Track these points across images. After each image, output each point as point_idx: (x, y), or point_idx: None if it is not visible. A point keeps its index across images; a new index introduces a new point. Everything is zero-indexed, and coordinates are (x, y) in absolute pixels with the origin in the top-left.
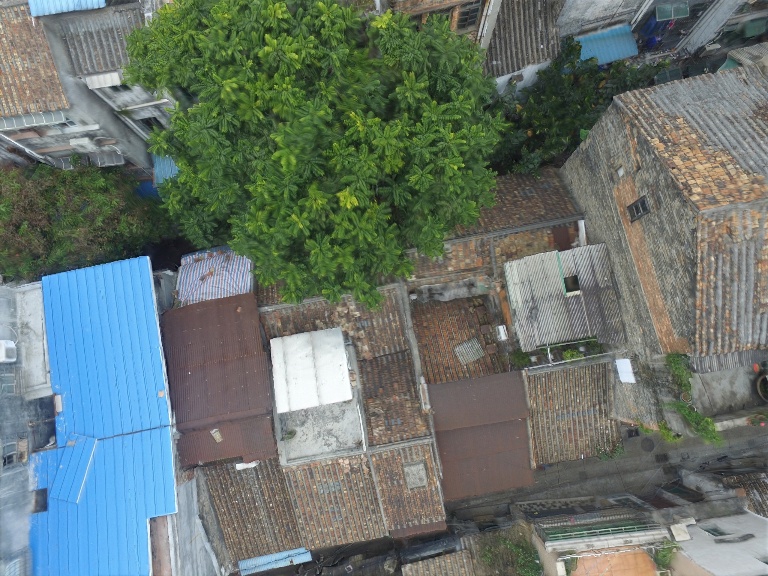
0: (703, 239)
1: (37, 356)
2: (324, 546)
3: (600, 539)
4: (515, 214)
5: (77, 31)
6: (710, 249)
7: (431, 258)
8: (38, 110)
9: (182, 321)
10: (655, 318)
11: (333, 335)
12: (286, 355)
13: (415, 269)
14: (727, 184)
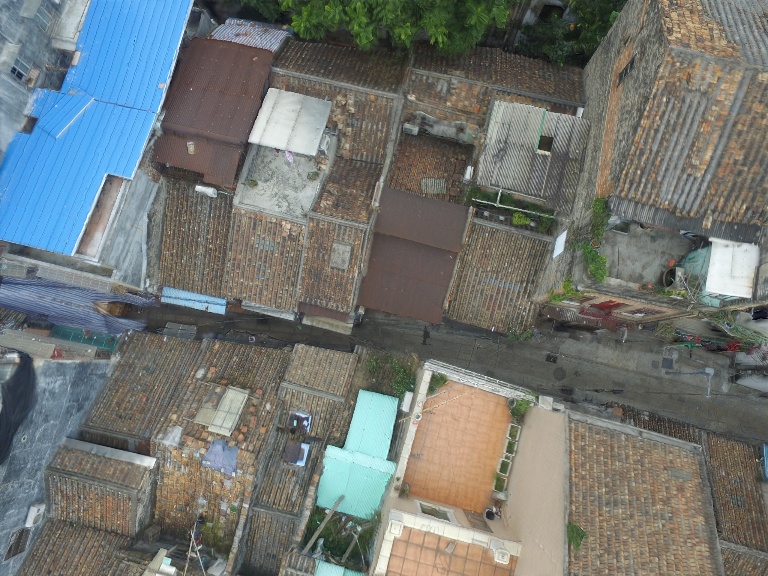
0: (663, 76)
1: (76, 16)
2: (239, 298)
3: (473, 378)
4: (526, 83)
5: None
6: (666, 89)
7: (436, 87)
8: None
9: (204, 49)
10: (600, 174)
11: (323, 105)
12: (277, 104)
13: (418, 91)
14: (706, 41)
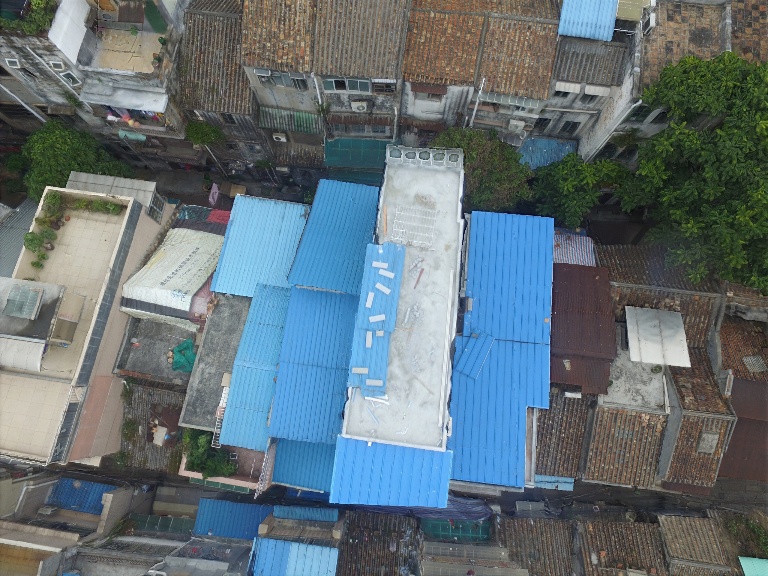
0: None
1: None
2: (600, 480)
3: None
4: None
5: (569, 50)
6: None
7: None
8: (525, 95)
9: None
10: None
11: (676, 317)
12: (638, 321)
13: (734, 288)
14: None
